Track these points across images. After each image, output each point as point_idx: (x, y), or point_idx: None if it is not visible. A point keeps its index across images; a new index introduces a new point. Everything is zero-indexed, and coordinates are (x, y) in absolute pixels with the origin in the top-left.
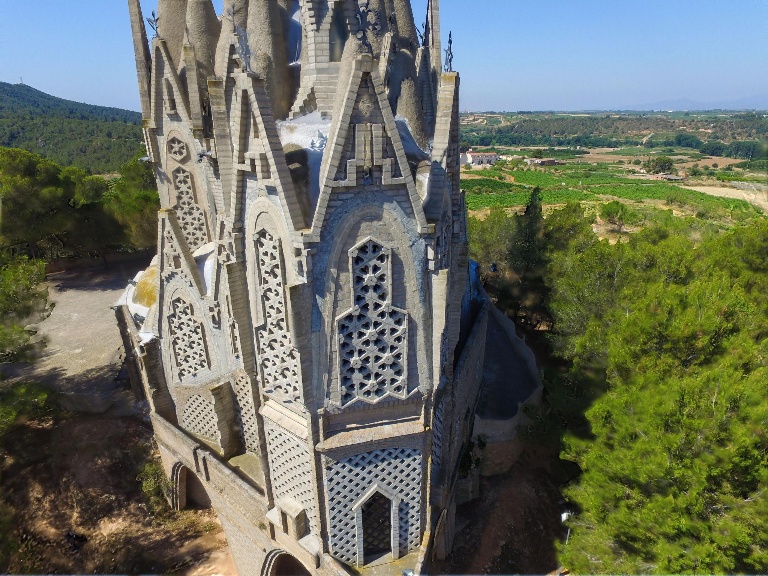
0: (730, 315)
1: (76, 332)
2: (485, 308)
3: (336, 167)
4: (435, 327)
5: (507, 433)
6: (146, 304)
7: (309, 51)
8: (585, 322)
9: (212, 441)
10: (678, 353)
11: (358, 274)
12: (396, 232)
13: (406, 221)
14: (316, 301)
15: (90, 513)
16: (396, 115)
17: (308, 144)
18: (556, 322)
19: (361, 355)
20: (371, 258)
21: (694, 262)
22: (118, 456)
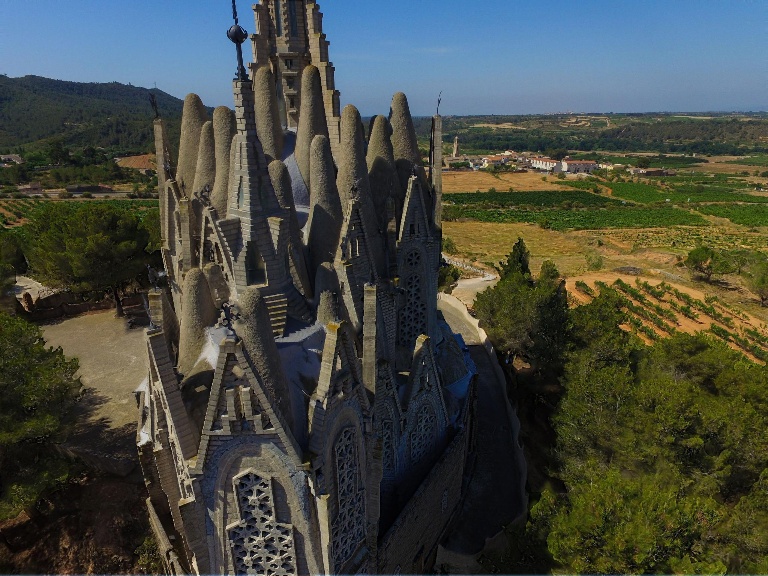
0: (684, 526)
1: (129, 379)
2: (456, 440)
3: (211, 421)
4: (322, 538)
5: (471, 567)
6: None
7: None
8: (583, 448)
9: None
10: (619, 557)
11: (243, 495)
12: (275, 466)
13: (284, 458)
14: (208, 513)
15: (101, 570)
16: (317, 320)
17: None
18: (559, 436)
19: (254, 554)
20: (254, 484)
21: (730, 385)
22: (130, 520)
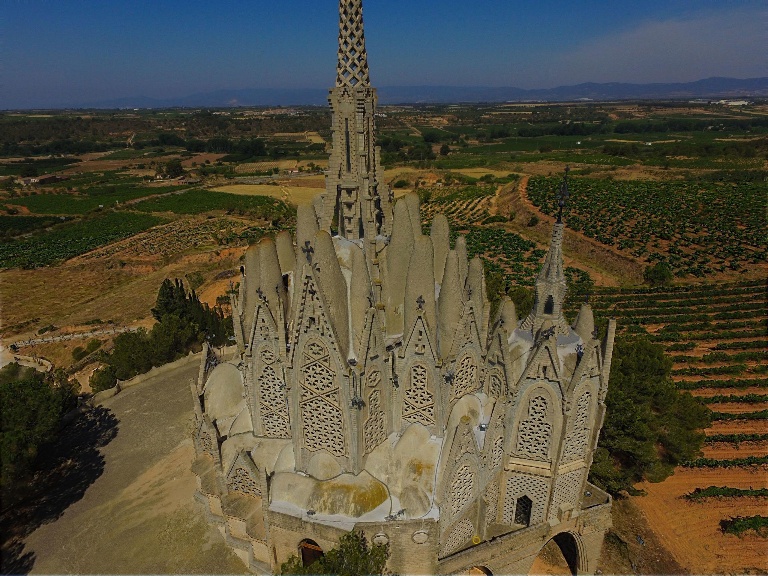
0: None
1: None
2: None
3: None
4: None
5: None
6: (371, 508)
7: (555, 312)
8: None
9: (462, 546)
10: None
11: None
12: None
13: None
14: None
15: None
16: None
17: (575, 351)
18: None
19: None
20: None
21: None
22: None
